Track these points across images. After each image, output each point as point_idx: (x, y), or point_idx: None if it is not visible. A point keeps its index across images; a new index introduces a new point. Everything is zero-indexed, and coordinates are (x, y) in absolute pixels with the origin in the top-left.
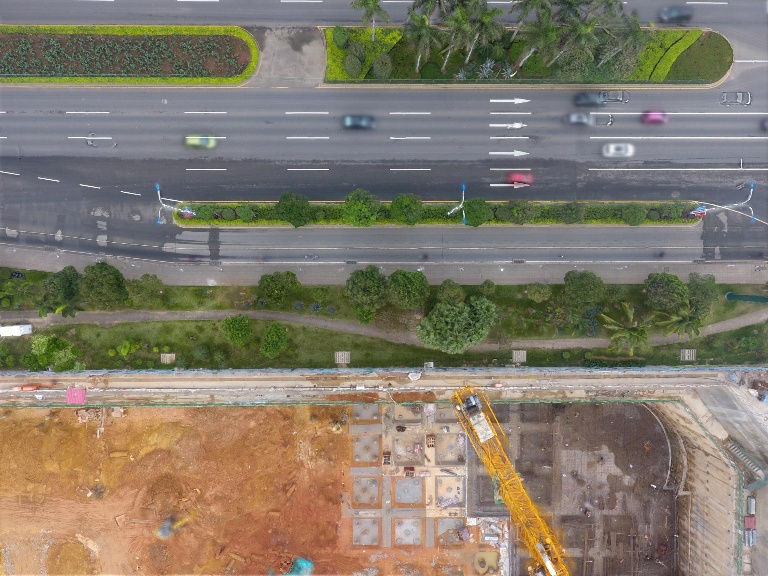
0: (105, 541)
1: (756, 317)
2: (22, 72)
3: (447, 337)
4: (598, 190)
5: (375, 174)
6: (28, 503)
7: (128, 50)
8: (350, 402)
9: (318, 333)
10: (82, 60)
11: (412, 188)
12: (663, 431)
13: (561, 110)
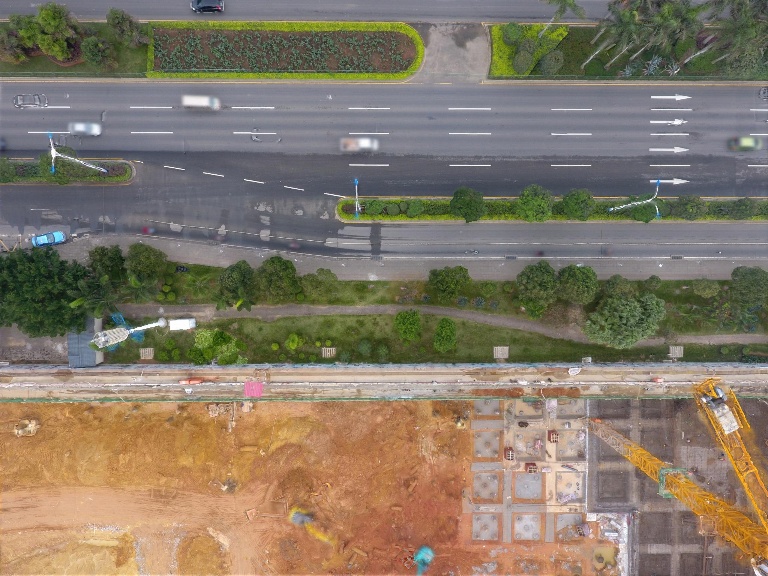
0: (235, 535)
1: None
2: (190, 67)
3: (621, 332)
4: (757, 186)
5: (536, 170)
6: (160, 497)
7: (294, 46)
8: (496, 397)
9: (477, 328)
10: (249, 56)
11: (573, 184)
12: None
13: (721, 107)
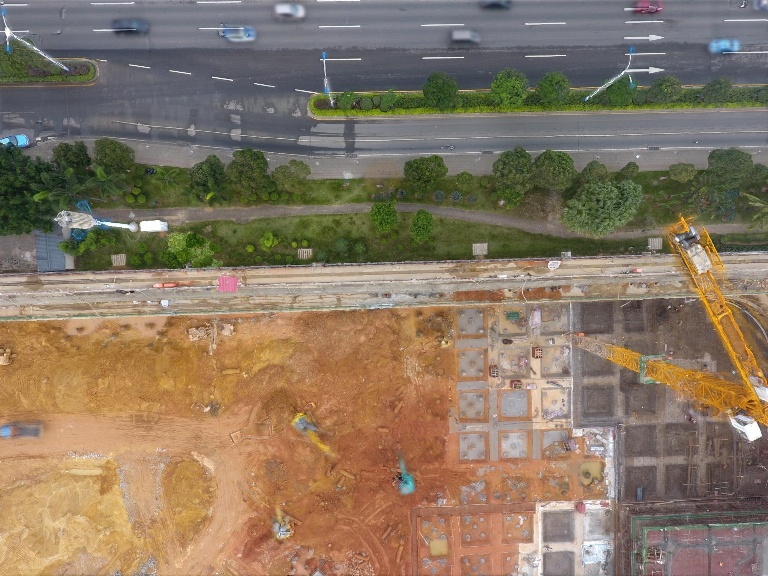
0: (221, 458)
1: None
2: None
3: (598, 216)
4: (732, 74)
5: (510, 61)
6: (142, 422)
7: None
8: (477, 301)
9: (455, 225)
10: None
11: None
12: (765, 337)
13: None
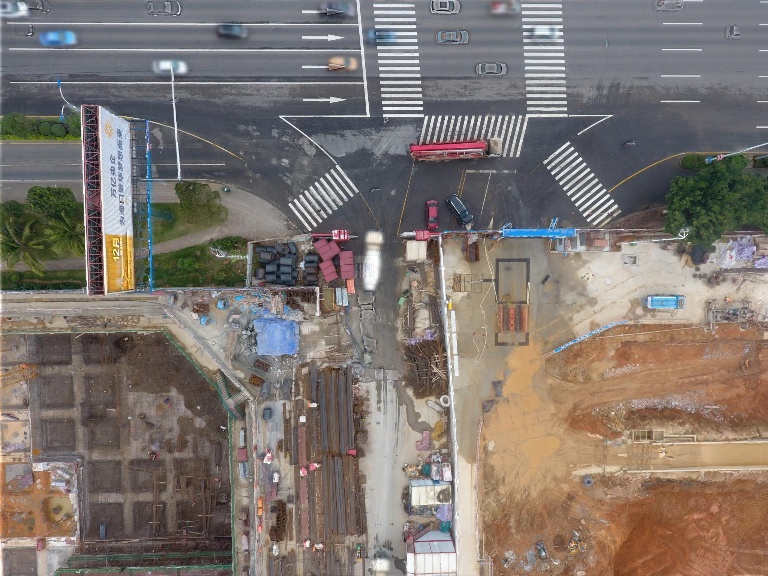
0: None
1: (198, 238)
2: None
3: None
4: (22, 105)
5: None
6: None
7: None
8: None
9: None
10: None
11: None
12: None
13: None
